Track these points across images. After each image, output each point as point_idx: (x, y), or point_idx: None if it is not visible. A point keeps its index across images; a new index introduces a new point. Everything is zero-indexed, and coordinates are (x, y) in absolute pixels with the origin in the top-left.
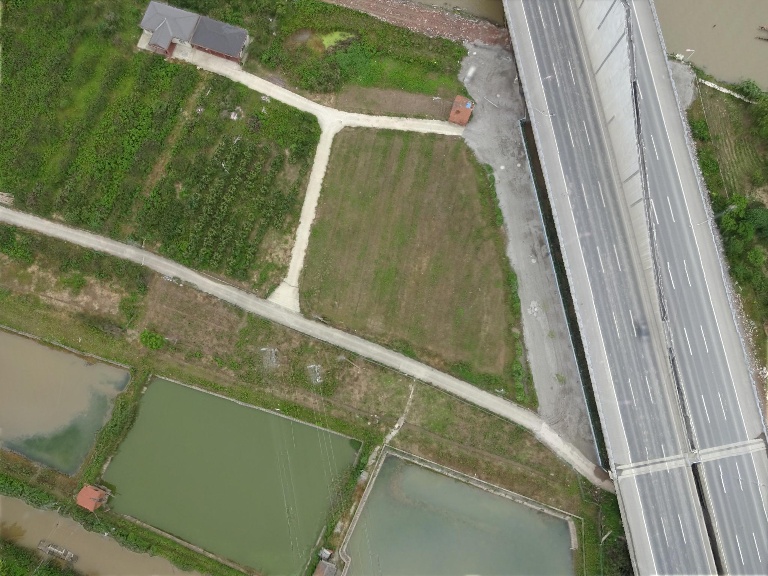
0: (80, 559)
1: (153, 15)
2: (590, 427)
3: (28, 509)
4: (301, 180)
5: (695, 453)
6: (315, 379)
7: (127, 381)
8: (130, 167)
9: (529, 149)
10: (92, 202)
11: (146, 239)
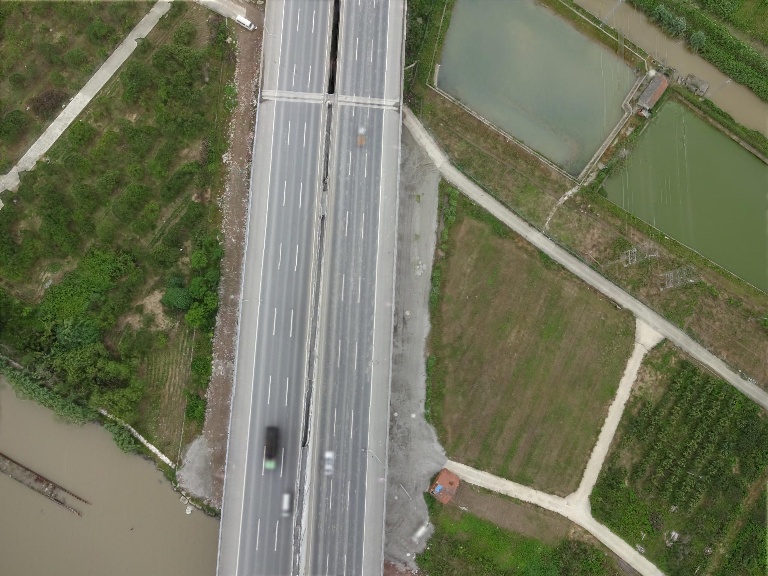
0: None
1: None
2: None
3: None
4: (617, 449)
5: None
6: None
7: None
8: None
9: None
10: None
11: None
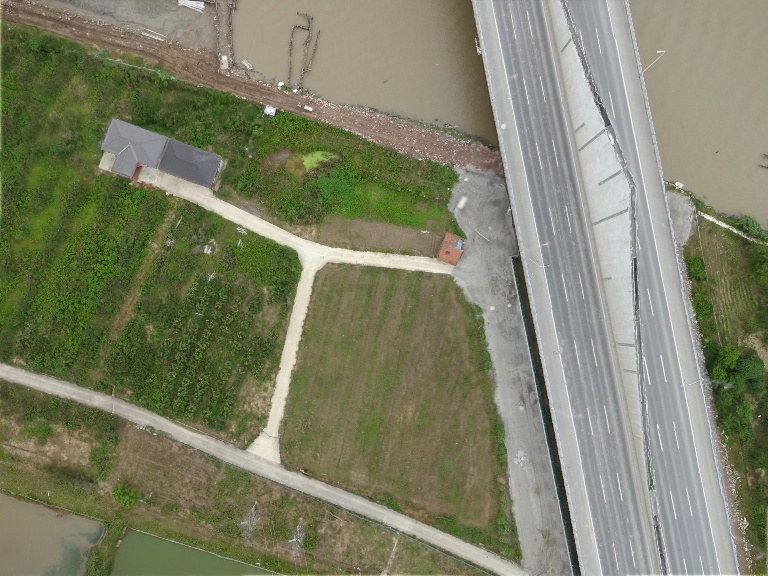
0: None
1: (115, 138)
2: None
3: None
4: (281, 322)
5: None
6: (296, 532)
7: (100, 533)
8: (96, 308)
9: (521, 292)
10: (55, 347)
11: (116, 388)
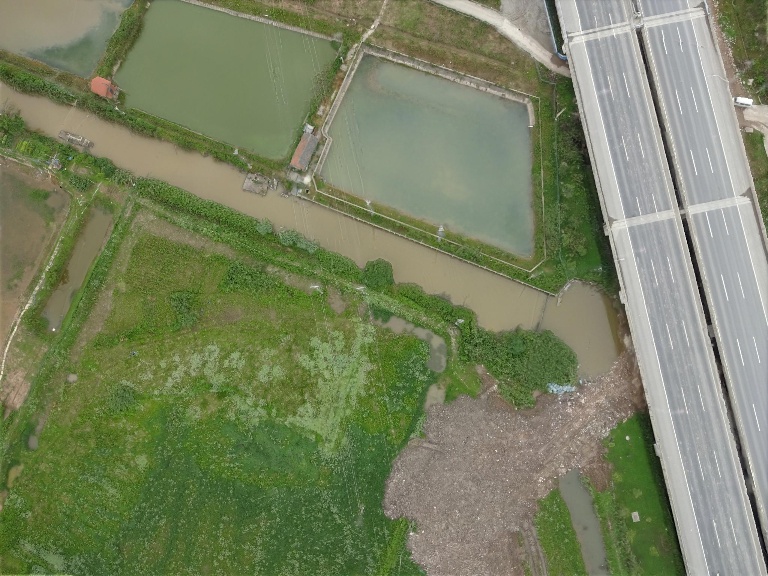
0: (96, 145)
1: None
2: (547, 21)
3: (49, 106)
4: None
5: (639, 19)
6: None
7: None
8: None
9: None
10: None
11: None
